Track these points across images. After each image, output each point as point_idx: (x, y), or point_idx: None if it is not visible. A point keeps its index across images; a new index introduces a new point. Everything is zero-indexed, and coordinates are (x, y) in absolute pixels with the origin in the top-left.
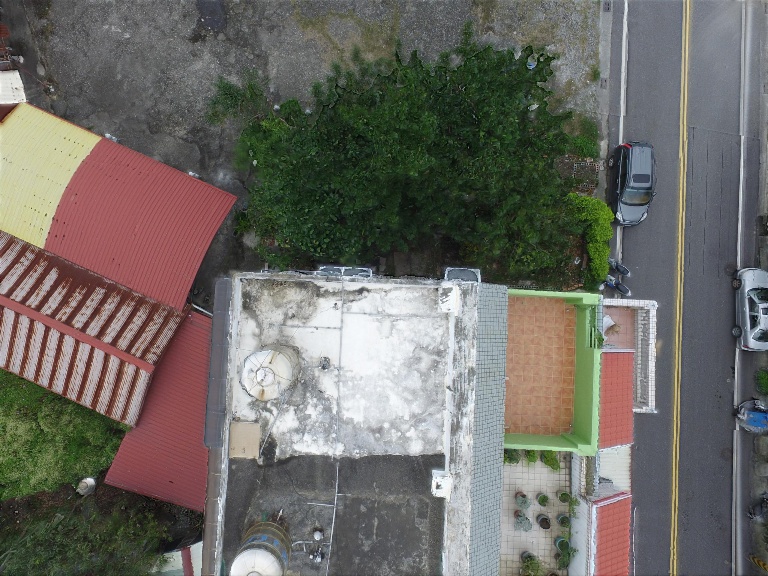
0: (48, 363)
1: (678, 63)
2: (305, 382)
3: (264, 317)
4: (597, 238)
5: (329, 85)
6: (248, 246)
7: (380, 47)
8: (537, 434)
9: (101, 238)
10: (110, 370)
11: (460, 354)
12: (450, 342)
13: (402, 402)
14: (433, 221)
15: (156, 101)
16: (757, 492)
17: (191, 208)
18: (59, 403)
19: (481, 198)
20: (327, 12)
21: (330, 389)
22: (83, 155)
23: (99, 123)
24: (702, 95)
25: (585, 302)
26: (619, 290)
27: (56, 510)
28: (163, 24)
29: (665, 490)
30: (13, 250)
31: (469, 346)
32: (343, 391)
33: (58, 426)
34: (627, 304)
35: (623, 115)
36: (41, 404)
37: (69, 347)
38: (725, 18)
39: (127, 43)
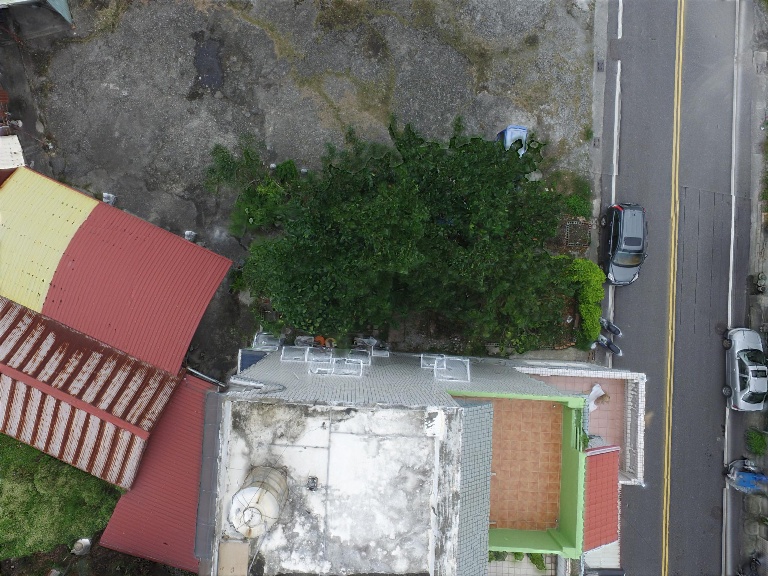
0: (44, 427)
1: (670, 123)
2: (293, 501)
3: (253, 436)
4: (589, 299)
5: (325, 143)
6: (244, 303)
7: (375, 106)
8: (523, 529)
9: (98, 304)
10: (105, 435)
11: (445, 479)
12: (435, 463)
13: (388, 521)
14: (424, 304)
15: (154, 158)
16: (746, 551)
17: (187, 273)
18: (55, 464)
19: (471, 287)
20: (323, 71)
21: (318, 508)
22: (80, 220)
23: (97, 180)
24: (694, 155)
25: (570, 406)
26: (611, 350)
27: (52, 566)
28: (161, 82)
29: (655, 548)
30: (11, 315)
31: (453, 471)
32: (330, 510)
33: (54, 488)
34: (616, 377)
35: (616, 175)
36: (37, 464)
37: (65, 413)
38: (717, 79)
39: (125, 101)
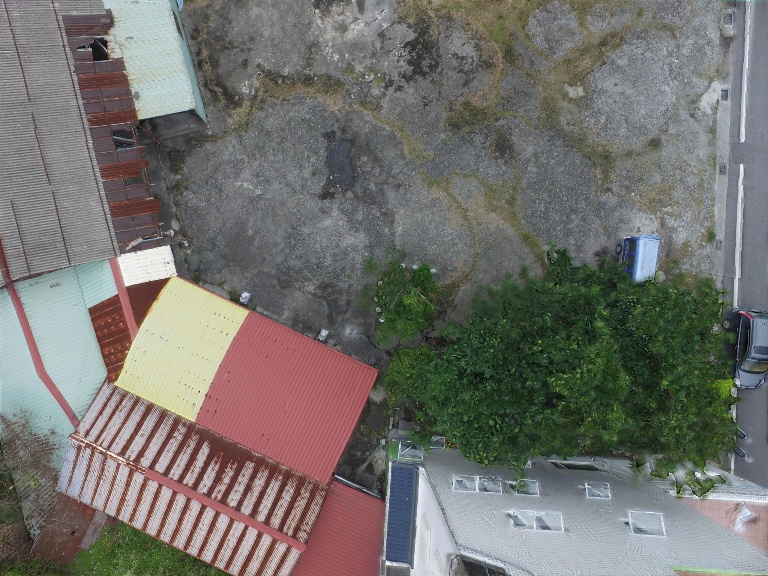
0: (200, 535)
1: None
2: None
3: None
4: None
5: (453, 243)
6: (374, 400)
7: (502, 207)
8: None
9: (252, 414)
10: (261, 545)
11: None
12: None
13: None
14: (602, 444)
15: (286, 256)
16: None
17: (337, 385)
18: (203, 566)
19: (660, 439)
20: (451, 172)
21: None
22: (234, 332)
23: (231, 277)
24: None
25: None
26: (735, 452)
27: None
28: (293, 181)
29: None
30: (167, 424)
31: None
32: None
33: None
34: (767, 501)
35: (738, 278)
36: (184, 564)
37: (223, 524)
38: None
39: (259, 200)
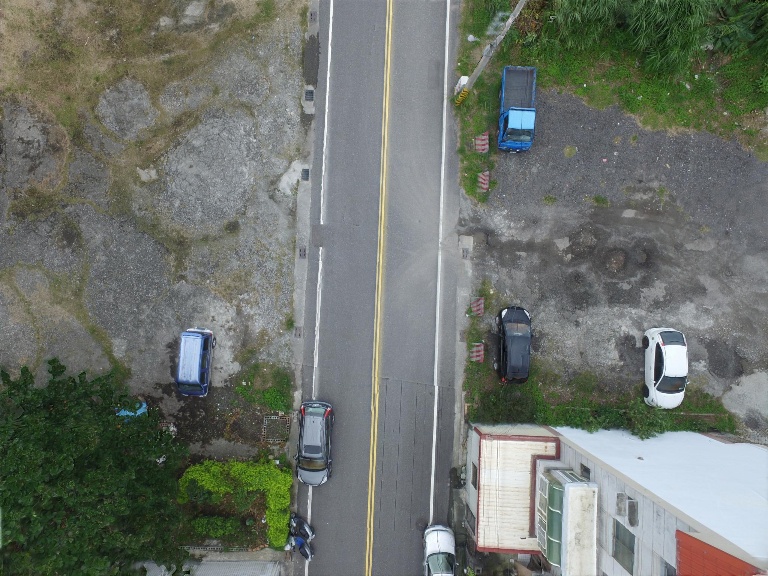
0: None
1: (372, 312)
2: None
3: None
4: (271, 507)
5: (16, 338)
6: None
7: (68, 299)
8: None
9: None
10: None
11: None
12: None
13: None
14: None
15: None
16: None
17: None
18: None
19: None
20: (15, 263)
21: None
22: None
23: None
24: (396, 345)
25: None
26: (302, 553)
27: None
28: None
29: None
30: None
31: None
32: None
33: None
34: None
35: (315, 367)
36: None
37: None
38: (421, 265)
39: None
